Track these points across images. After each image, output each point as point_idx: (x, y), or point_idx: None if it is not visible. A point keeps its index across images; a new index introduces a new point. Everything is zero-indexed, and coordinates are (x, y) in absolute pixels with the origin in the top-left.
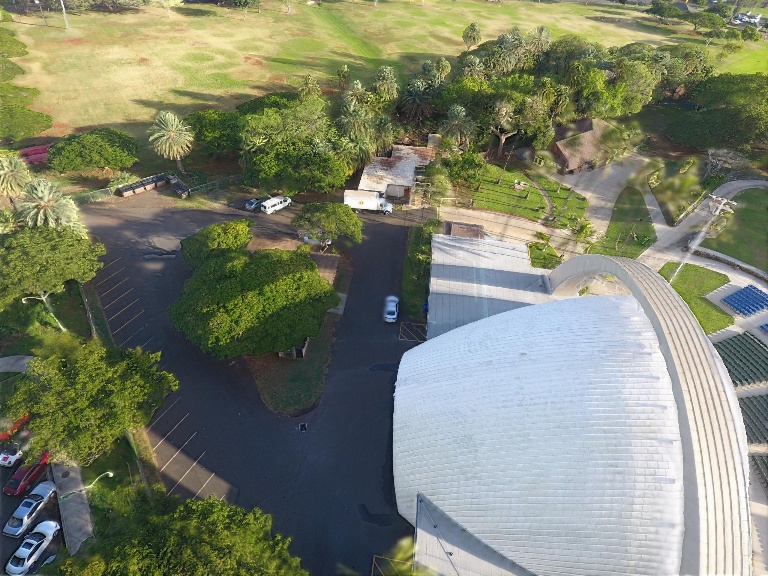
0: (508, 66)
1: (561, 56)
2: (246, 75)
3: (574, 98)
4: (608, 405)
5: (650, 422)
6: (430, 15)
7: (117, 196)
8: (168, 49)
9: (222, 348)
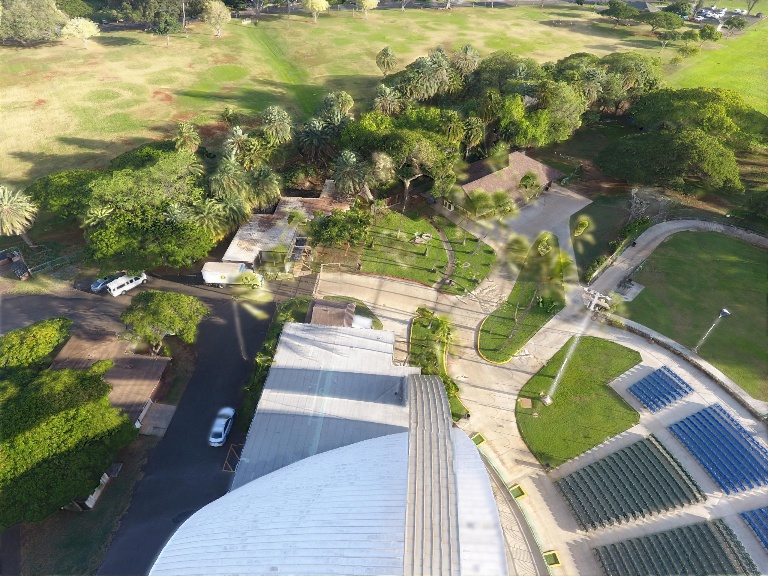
0: (429, 91)
1: (493, 74)
2: (149, 114)
3: (492, 128)
4: None
5: None
6: (371, 29)
7: None
8: (72, 87)
9: None
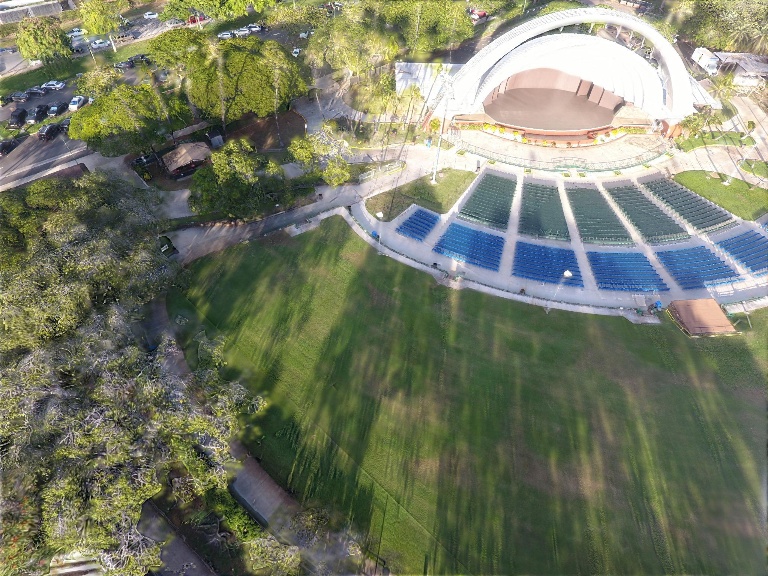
0: None
1: None
2: None
3: None
4: None
5: None
6: None
7: (619, 2)
8: None
9: None
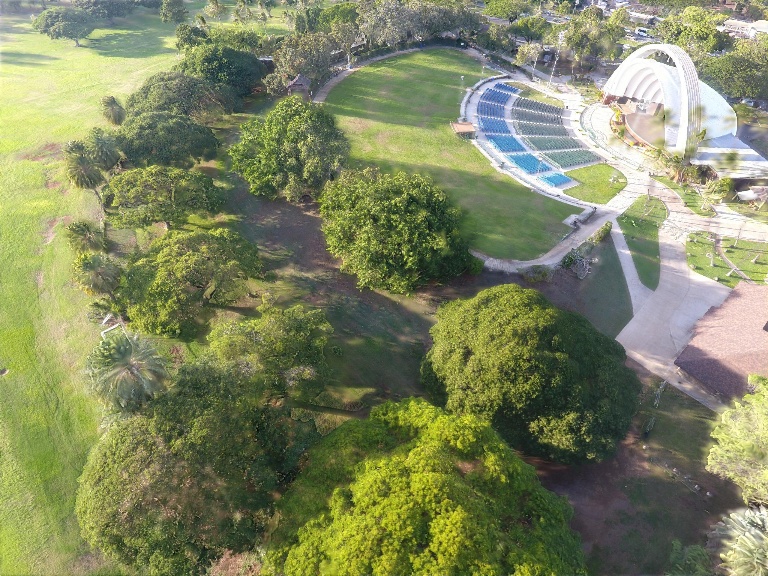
0: None
1: None
2: None
3: None
4: None
5: None
6: None
7: None
8: None
9: None
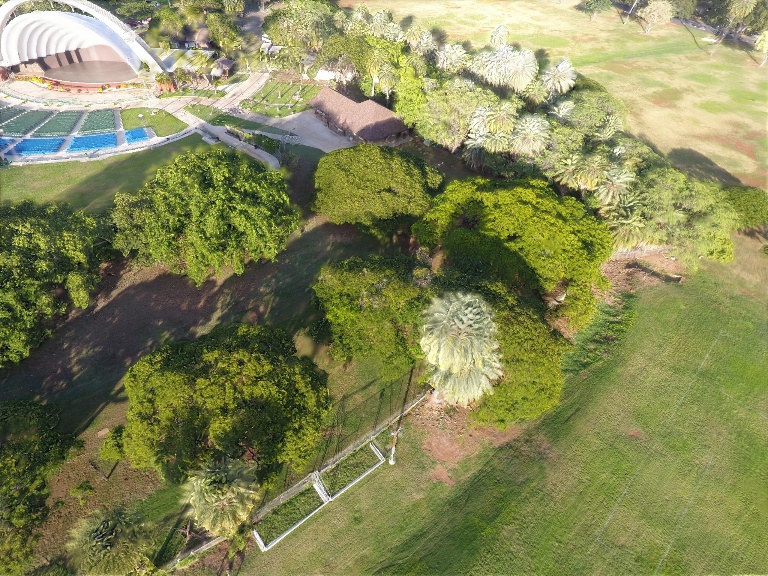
0: (492, 77)
1: None
2: (454, 29)
3: None
4: None
5: None
6: None
7: None
8: None
9: None
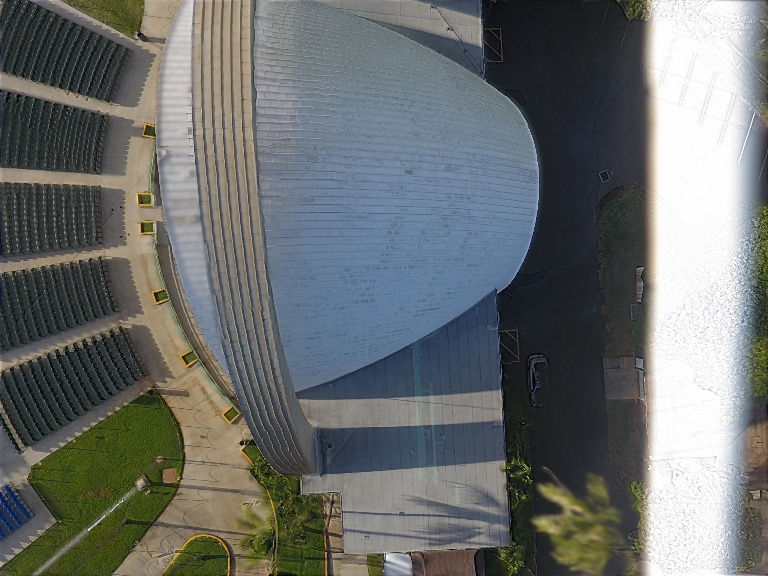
0: None
1: None
2: None
3: None
4: (316, 83)
5: (271, 62)
6: None
7: None
8: None
9: (764, 206)
